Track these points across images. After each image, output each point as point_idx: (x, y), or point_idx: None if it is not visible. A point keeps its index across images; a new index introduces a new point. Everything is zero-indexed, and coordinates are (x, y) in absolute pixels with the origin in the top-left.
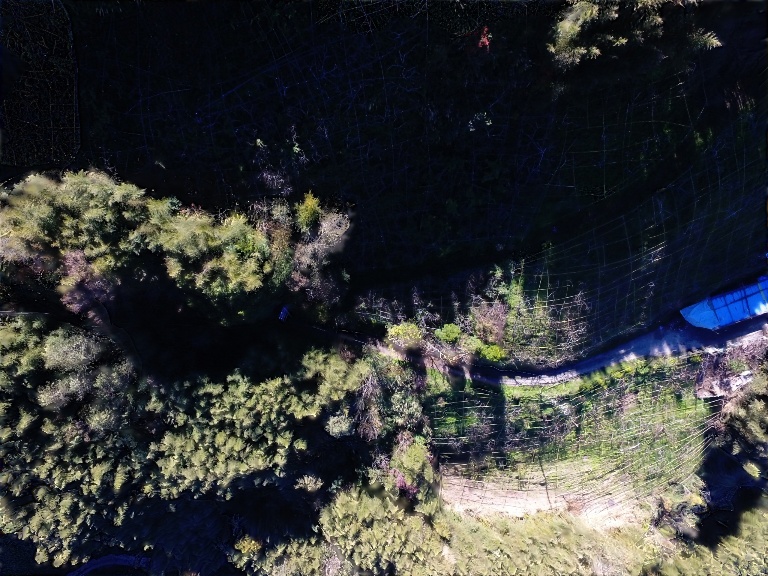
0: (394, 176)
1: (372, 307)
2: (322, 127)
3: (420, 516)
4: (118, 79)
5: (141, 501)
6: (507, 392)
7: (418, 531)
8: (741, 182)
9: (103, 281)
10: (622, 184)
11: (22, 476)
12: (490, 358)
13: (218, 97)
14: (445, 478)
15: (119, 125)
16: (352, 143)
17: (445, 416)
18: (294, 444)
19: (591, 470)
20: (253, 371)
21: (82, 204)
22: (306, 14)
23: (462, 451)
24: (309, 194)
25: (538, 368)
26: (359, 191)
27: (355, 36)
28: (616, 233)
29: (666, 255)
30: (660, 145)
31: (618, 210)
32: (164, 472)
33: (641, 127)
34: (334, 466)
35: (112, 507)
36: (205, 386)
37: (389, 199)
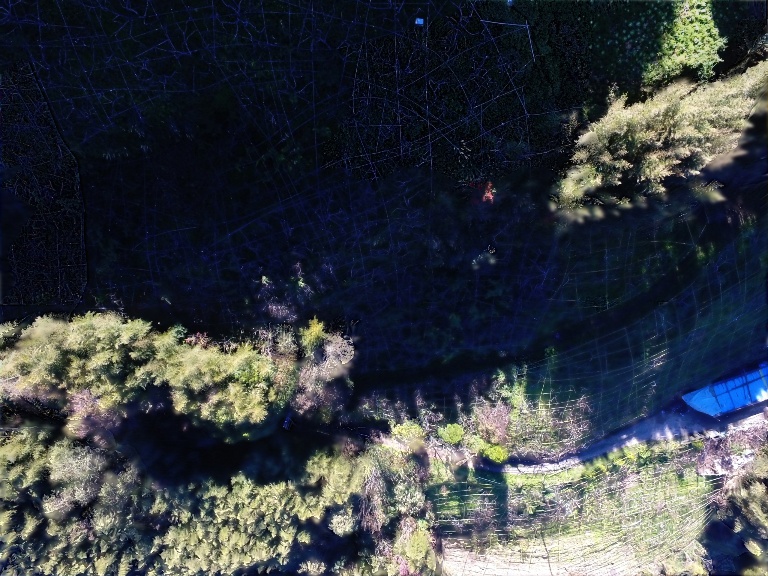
0: (398, 295)
1: (375, 406)
2: (327, 264)
3: None
4: (124, 217)
5: None
6: (510, 480)
7: None
8: (742, 292)
9: (109, 412)
10: (624, 297)
11: (26, 571)
12: (493, 459)
13: (224, 236)
14: (447, 550)
15: (125, 262)
16: (356, 273)
17: (448, 500)
18: (297, 537)
19: (593, 544)
20: (257, 475)
21: (89, 348)
22: (311, 159)
23: (465, 530)
24: (314, 320)
25: (541, 460)
26: (363, 309)
27: (360, 182)
28: (618, 342)
29: (668, 360)
30: (662, 260)
31: (620, 320)
32: (168, 563)
33: (643, 247)
34: (337, 546)
35: None
36: (209, 490)
37: (393, 314)
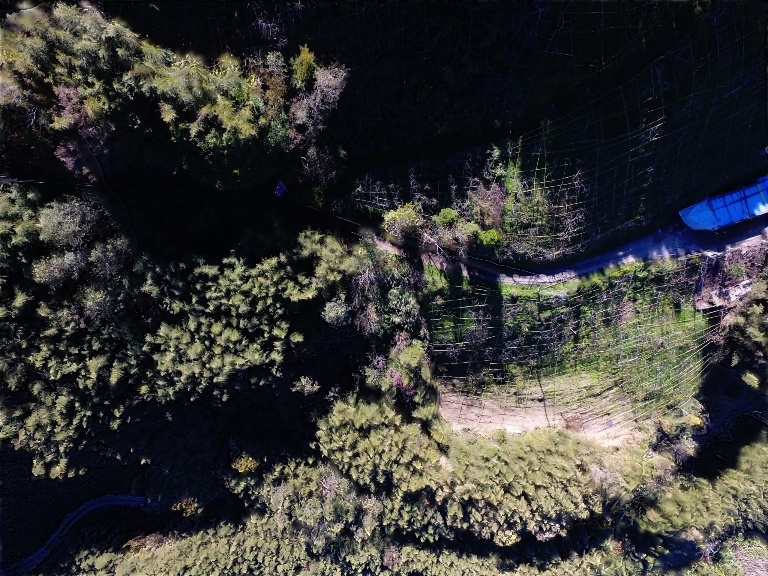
0: (390, 39)
1: (369, 193)
2: None
3: (417, 423)
4: None
5: (137, 405)
6: (505, 290)
7: (415, 436)
8: (740, 54)
9: (97, 129)
10: (620, 53)
11: (18, 366)
12: (487, 242)
13: None
14: (443, 395)
15: None
16: None
17: (442, 319)
18: (290, 337)
19: (589, 385)
20: (249, 251)
21: (75, 36)
22: None
23: (460, 360)
24: (304, 48)
25: (536, 262)
26: (355, 55)
27: None
28: (614, 106)
29: (665, 134)
30: (659, 11)
31: (616, 83)
32: (160, 367)
33: None
34: (331, 374)
35: (108, 410)
36: (201, 266)
37: (385, 65)
